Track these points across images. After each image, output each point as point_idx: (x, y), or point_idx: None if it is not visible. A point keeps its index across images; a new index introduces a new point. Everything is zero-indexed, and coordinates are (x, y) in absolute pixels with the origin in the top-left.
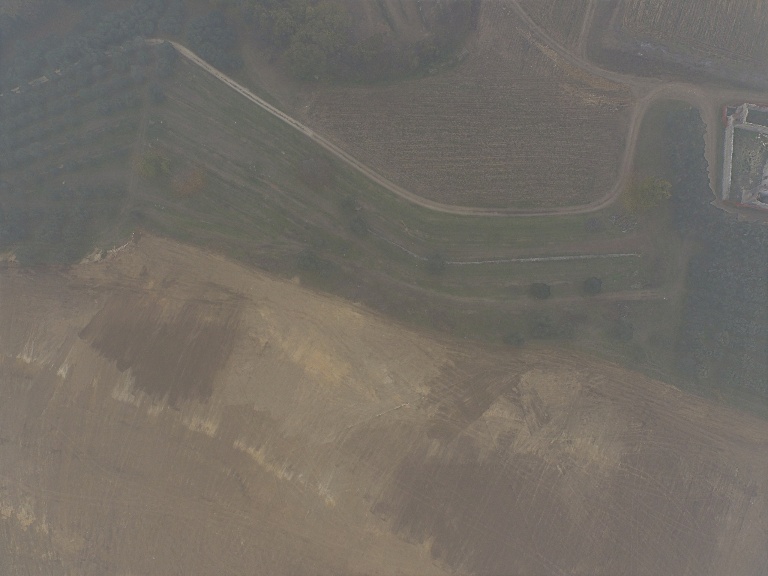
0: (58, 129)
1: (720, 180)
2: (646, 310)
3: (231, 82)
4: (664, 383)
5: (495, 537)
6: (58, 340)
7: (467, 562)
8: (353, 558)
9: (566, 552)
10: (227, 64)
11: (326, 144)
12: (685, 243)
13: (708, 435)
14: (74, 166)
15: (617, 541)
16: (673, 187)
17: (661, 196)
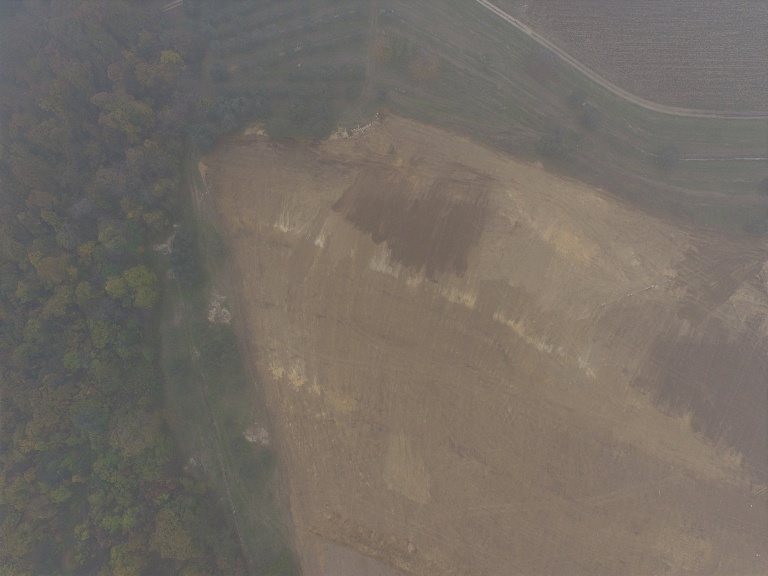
0: (289, 14)
1: None
2: None
3: None
4: None
5: (751, 414)
6: (312, 212)
7: (726, 436)
8: (617, 429)
9: None
10: None
11: (545, 43)
12: None
13: None
14: (313, 47)
15: None
16: None
17: None
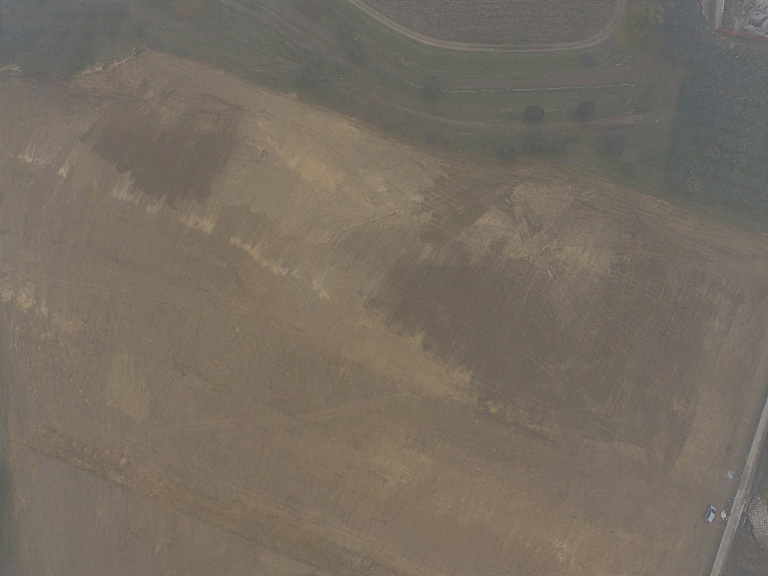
0: None
1: (713, 11)
2: (638, 133)
3: None
4: (655, 198)
5: (486, 334)
6: (59, 143)
7: (458, 355)
8: (346, 348)
9: (555, 350)
10: None
11: None
12: (678, 70)
13: (697, 247)
14: None
15: (606, 342)
16: (667, 15)
17: (654, 20)
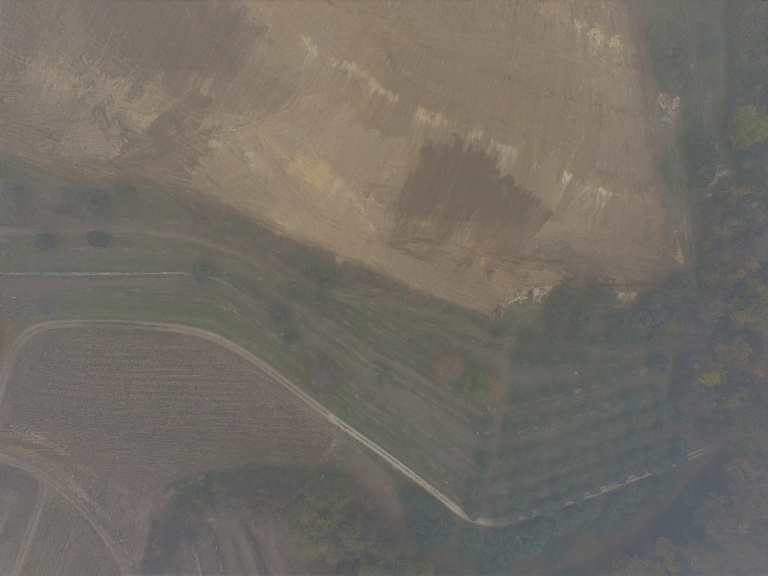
0: (584, 431)
1: None
2: None
3: (411, 475)
4: None
5: None
6: (573, 209)
7: None
8: None
9: None
10: (413, 494)
11: (315, 405)
12: None
13: None
14: (563, 389)
15: None
16: None
17: None
